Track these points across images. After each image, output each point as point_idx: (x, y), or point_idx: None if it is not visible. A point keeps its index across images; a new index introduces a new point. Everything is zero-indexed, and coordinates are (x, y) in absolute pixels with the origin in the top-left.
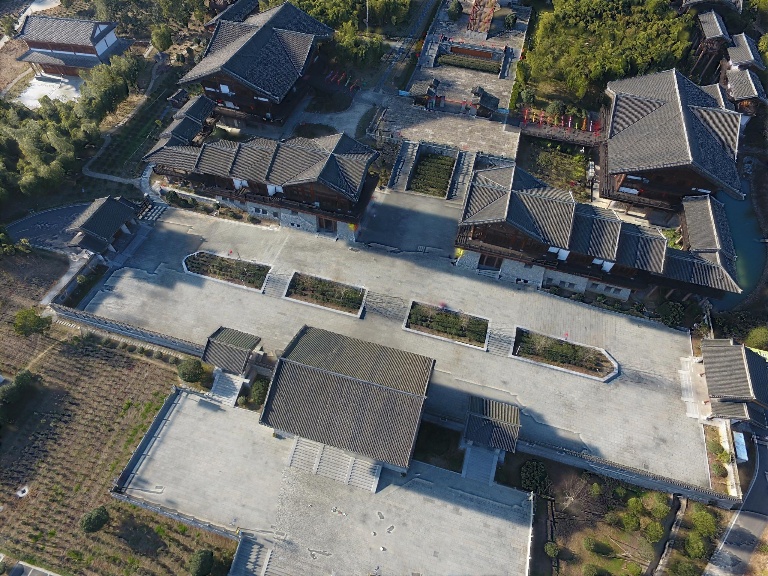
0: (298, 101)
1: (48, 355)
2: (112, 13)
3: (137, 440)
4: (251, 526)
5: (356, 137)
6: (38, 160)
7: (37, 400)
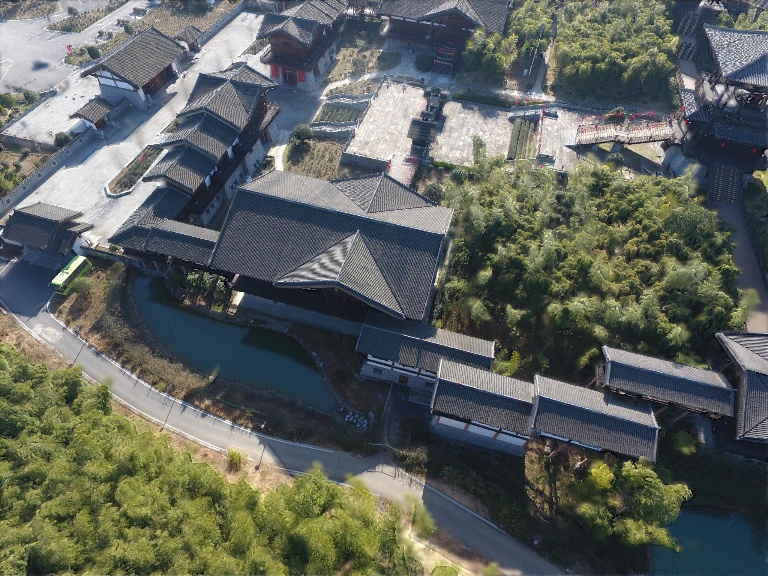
0: (412, 39)
1: (222, 11)
2: None
3: None
4: None
5: None
6: None
7: (197, 12)
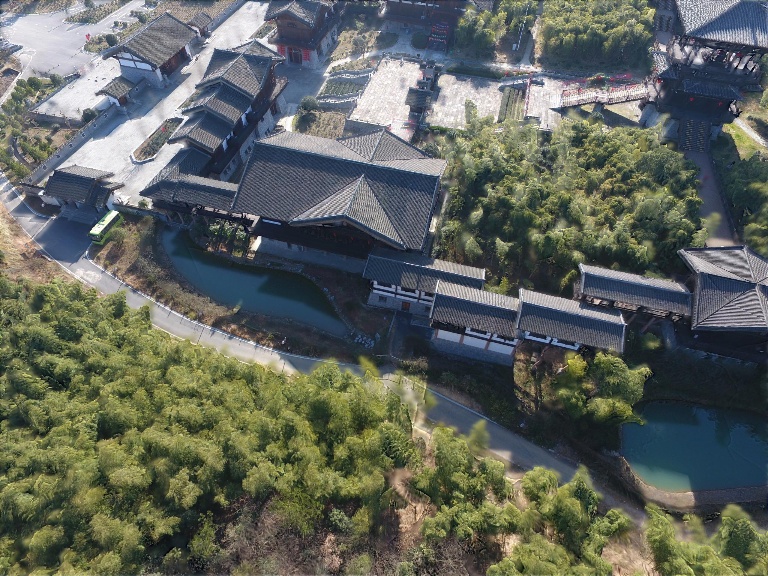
0: (408, 20)
1: None
2: None
3: None
4: None
5: None
6: None
7: (205, 2)
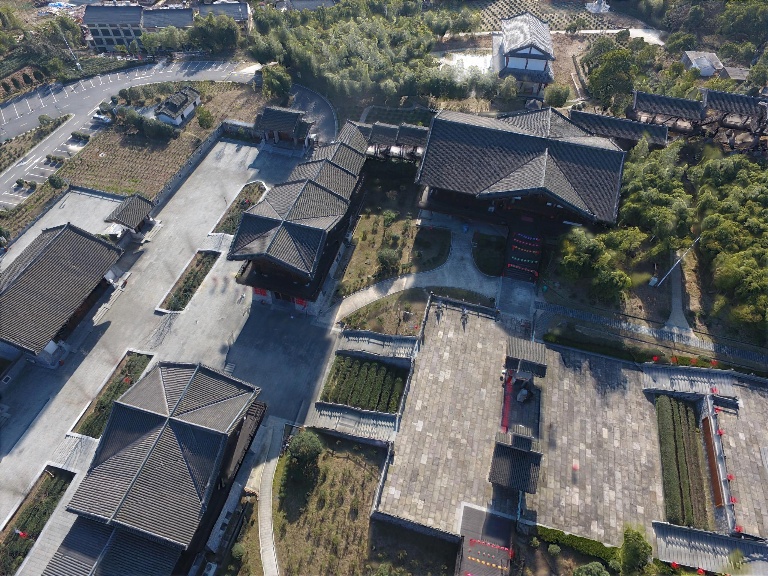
0: (468, 215)
1: (191, 137)
2: (590, 57)
3: (108, 191)
4: (8, 255)
5: (429, 288)
6: (344, 72)
7: (157, 141)
